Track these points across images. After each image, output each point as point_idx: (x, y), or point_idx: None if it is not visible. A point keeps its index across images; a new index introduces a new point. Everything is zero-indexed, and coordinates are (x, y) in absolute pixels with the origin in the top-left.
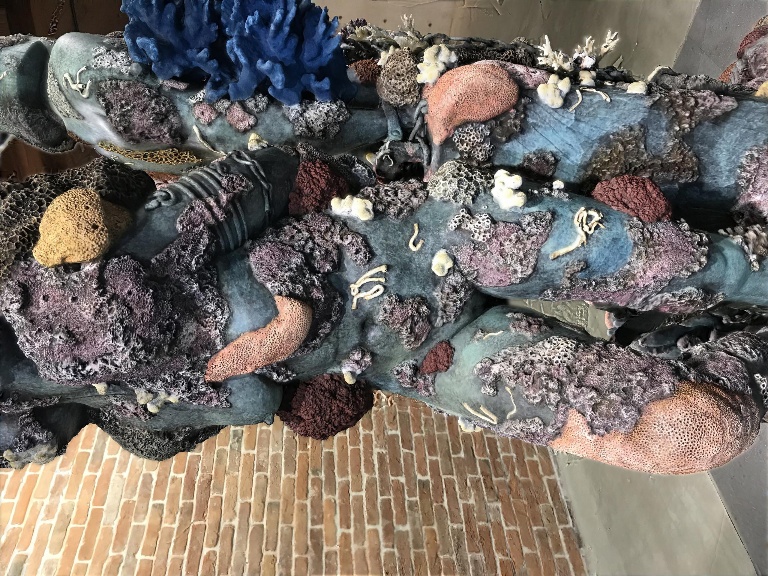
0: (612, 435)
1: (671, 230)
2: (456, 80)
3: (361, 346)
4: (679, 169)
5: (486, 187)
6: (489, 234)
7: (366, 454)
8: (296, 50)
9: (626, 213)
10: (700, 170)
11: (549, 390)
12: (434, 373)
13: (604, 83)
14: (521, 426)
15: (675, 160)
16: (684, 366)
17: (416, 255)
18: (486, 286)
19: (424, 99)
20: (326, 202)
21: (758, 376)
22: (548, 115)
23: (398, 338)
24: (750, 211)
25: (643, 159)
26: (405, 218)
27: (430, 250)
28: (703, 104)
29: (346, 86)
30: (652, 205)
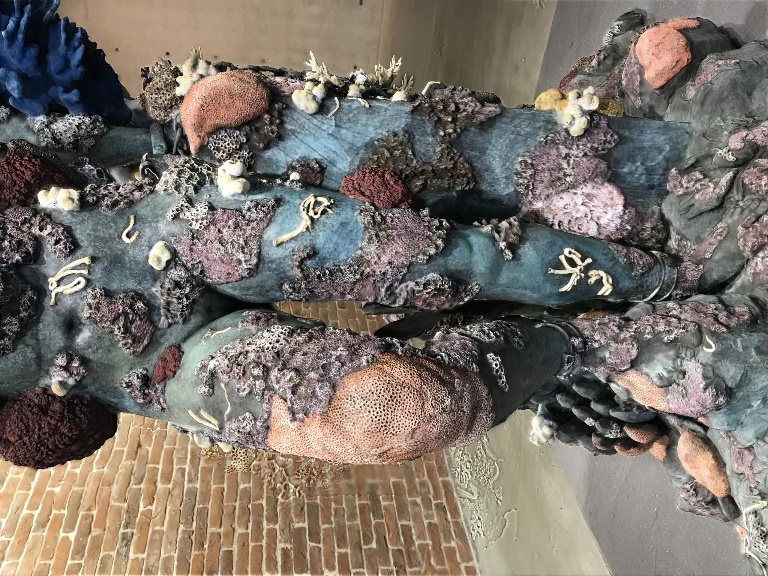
0: (311, 419)
1: (407, 215)
2: (201, 84)
3: (68, 349)
4: (452, 176)
5: (214, 179)
6: (206, 221)
7: (269, 551)
8: (39, 61)
9: (362, 200)
10: (475, 177)
11: (256, 379)
12: (164, 382)
13: (376, 97)
14: (236, 426)
15: (446, 166)
16: (398, 342)
17: (130, 248)
18: (218, 283)
19: (177, 108)
20: (35, 197)
21: (491, 355)
22: (307, 121)
23: (113, 340)
24: (535, 219)
25: (413, 166)
26: (121, 210)
27: (147, 242)
28: (465, 109)
29: (118, 108)
30: (387, 191)
